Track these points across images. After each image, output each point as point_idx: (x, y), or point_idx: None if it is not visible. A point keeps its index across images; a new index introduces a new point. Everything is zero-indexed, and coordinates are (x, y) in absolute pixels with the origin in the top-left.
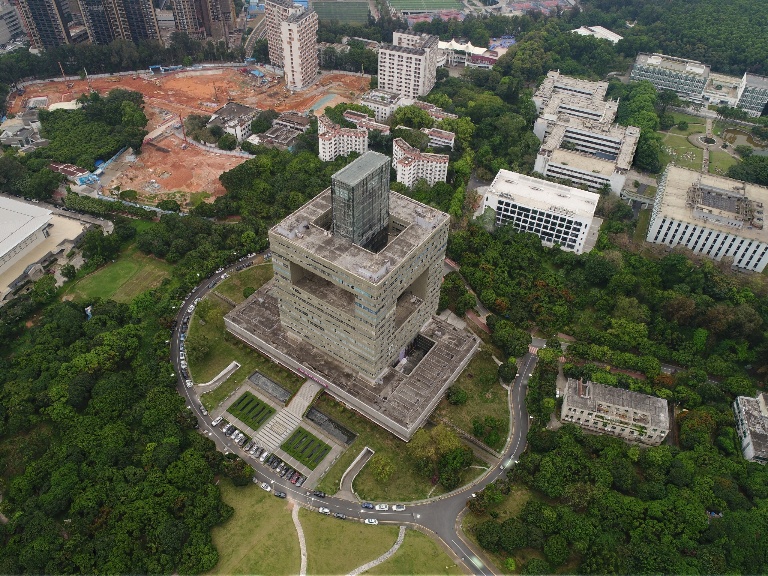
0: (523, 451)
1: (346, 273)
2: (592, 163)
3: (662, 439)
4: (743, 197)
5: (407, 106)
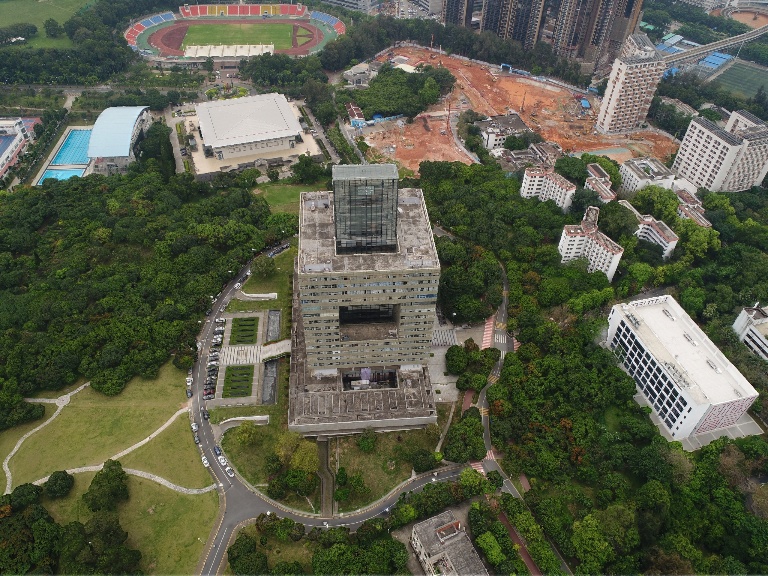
0: (356, 530)
1: None
2: None
3: None
4: None
5: (660, 187)
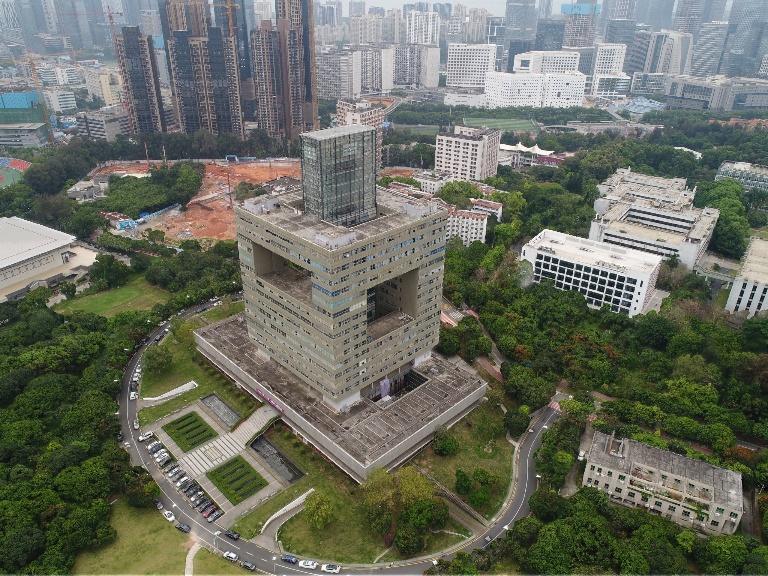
0: None
1: (301, 241)
2: (657, 234)
3: (734, 529)
4: None
5: (456, 181)
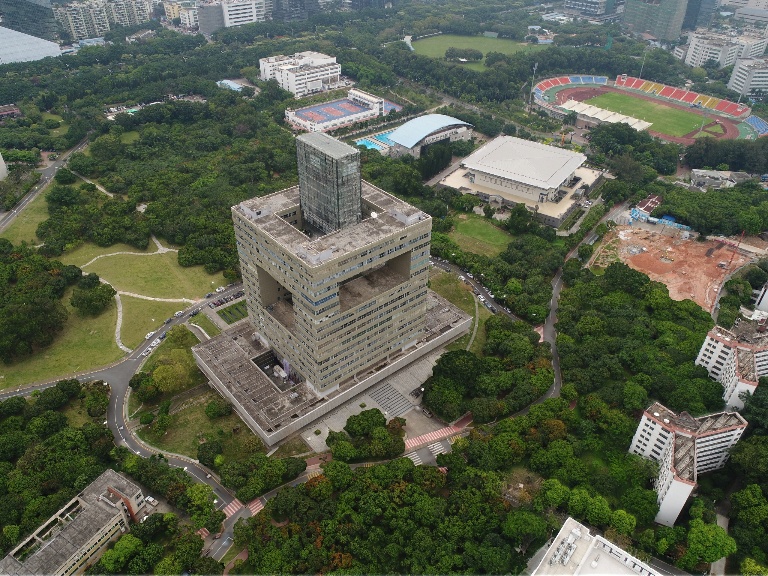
0: None
1: None
2: None
3: None
4: None
5: None
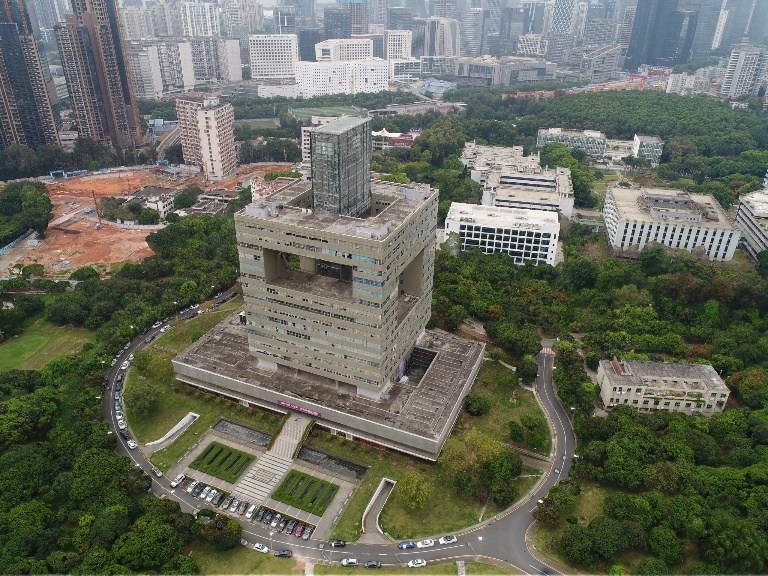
0: (574, 449)
1: (341, 238)
2: (537, 194)
3: (723, 406)
4: (689, 200)
5: None
